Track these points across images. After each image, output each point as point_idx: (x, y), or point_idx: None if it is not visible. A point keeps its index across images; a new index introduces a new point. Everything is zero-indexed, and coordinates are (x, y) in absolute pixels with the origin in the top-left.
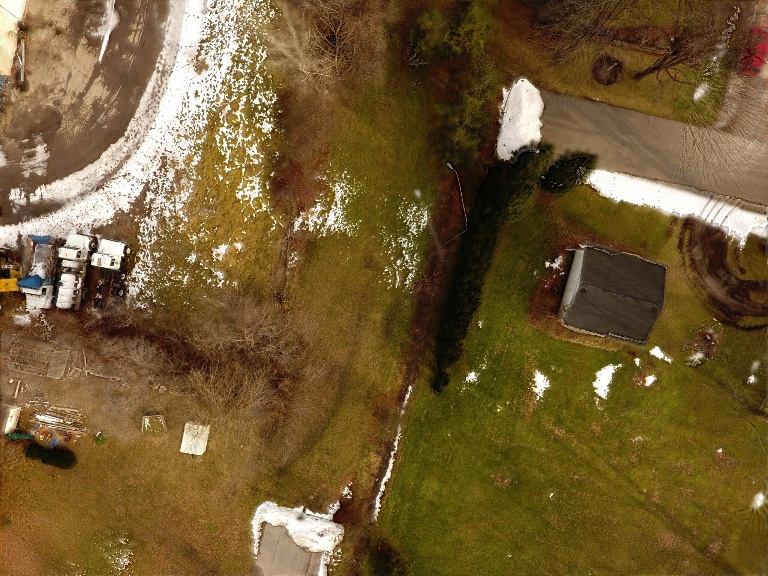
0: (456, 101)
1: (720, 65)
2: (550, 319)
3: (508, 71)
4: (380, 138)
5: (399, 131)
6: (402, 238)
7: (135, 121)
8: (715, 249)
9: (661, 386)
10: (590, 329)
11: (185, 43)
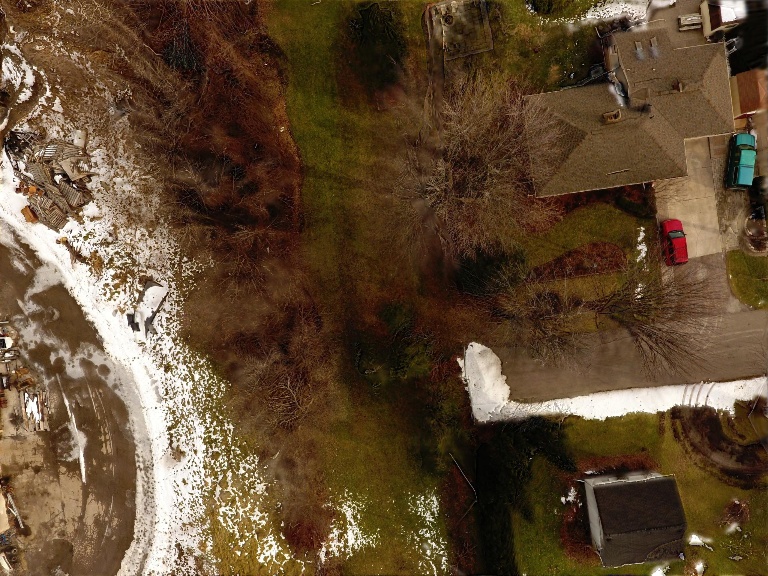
0: (424, 420)
1: (647, 286)
2: (587, 549)
3: (454, 339)
4: (365, 447)
5: (379, 434)
6: (422, 530)
7: (138, 522)
8: (709, 427)
9: (713, 574)
10: (629, 562)
11: (154, 436)
